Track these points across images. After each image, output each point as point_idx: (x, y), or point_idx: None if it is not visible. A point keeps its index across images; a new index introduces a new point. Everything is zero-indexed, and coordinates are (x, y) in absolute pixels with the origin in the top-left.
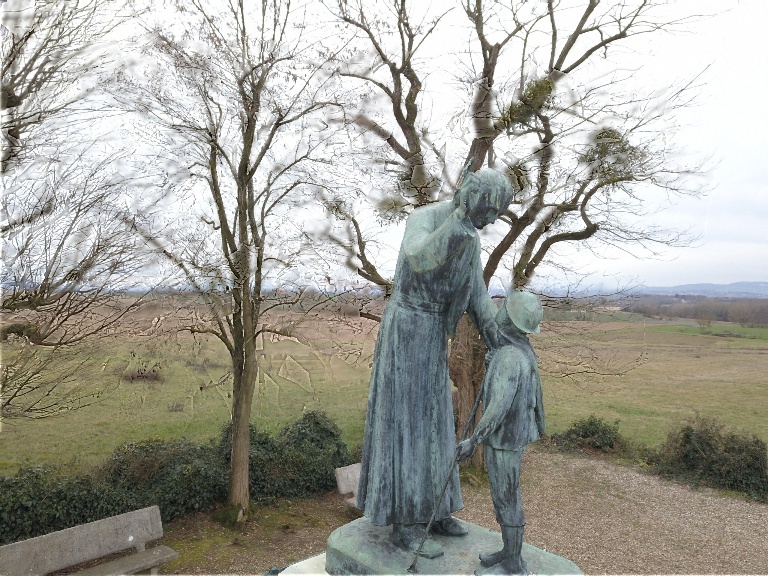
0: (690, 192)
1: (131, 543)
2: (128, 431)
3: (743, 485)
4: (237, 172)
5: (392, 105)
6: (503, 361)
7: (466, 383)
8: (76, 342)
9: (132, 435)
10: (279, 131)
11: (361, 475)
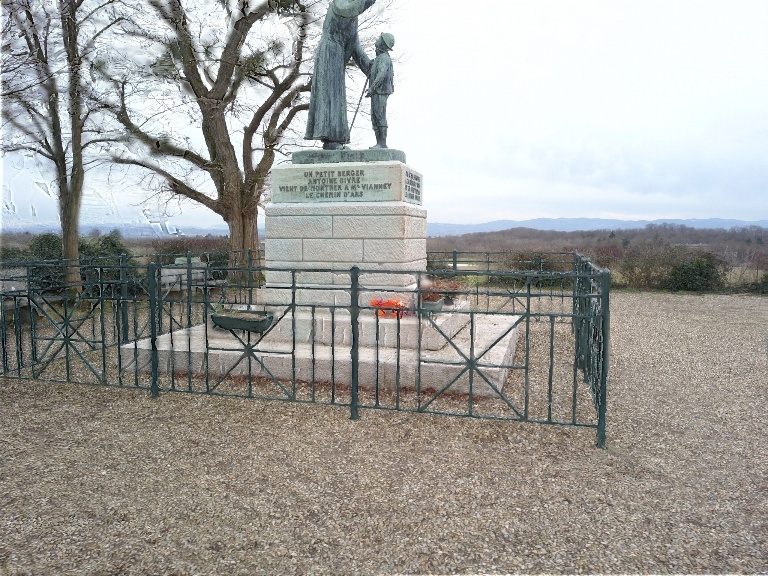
0: None
1: None
2: None
3: None
4: None
5: None
6: (383, 57)
7: (237, 215)
8: (5, 96)
9: None
10: None
11: (309, 122)
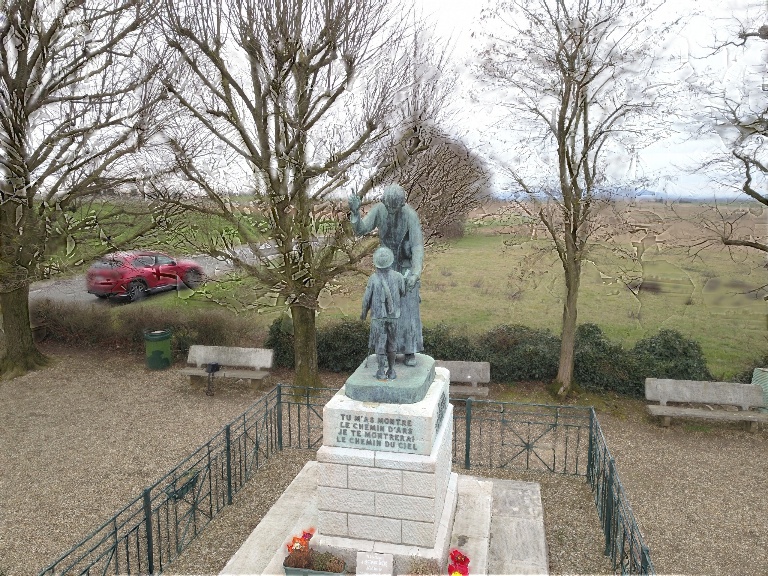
0: None
1: (469, 380)
2: (506, 316)
3: None
4: (557, 129)
5: None
6: None
7: None
8: None
9: (509, 319)
10: (582, 92)
11: None
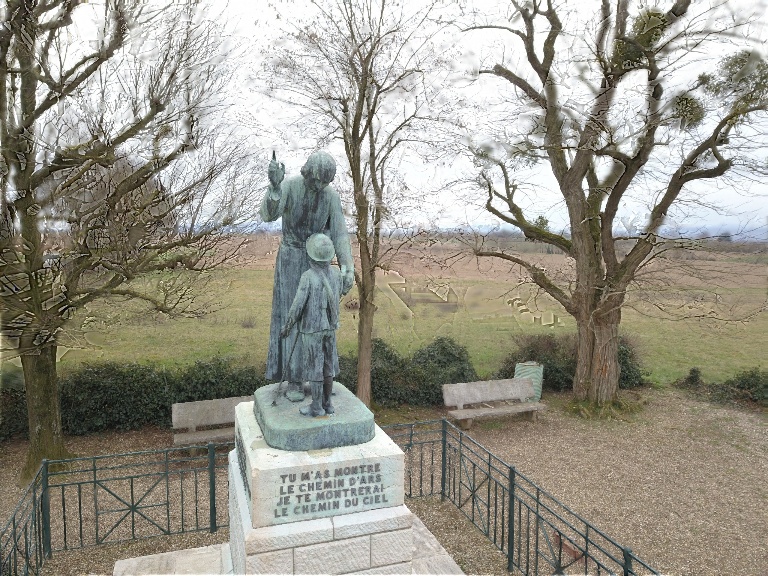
0: None
1: None
2: None
3: None
4: (351, 135)
5: (526, 51)
6: None
7: None
8: (212, 269)
9: None
10: (380, 98)
11: None
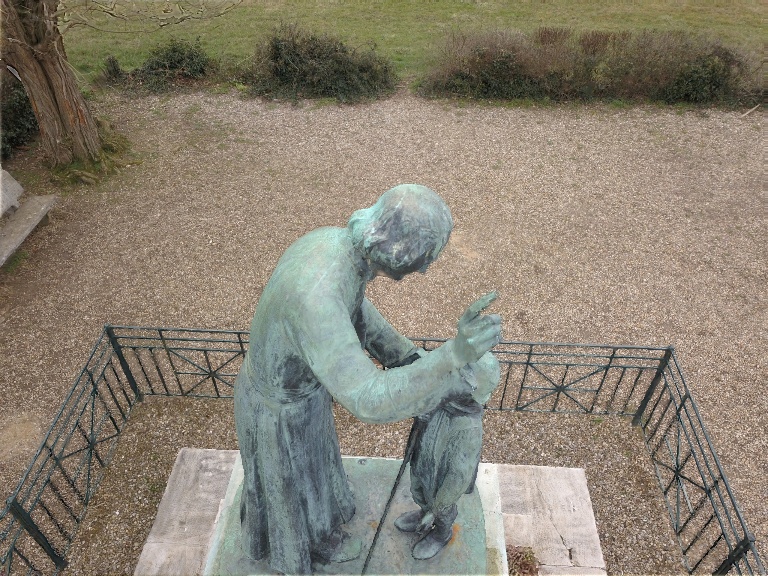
0: None
1: None
2: None
3: (333, 90)
4: None
5: None
6: (469, 444)
7: (27, 62)
8: None
9: None
10: None
11: (253, 541)
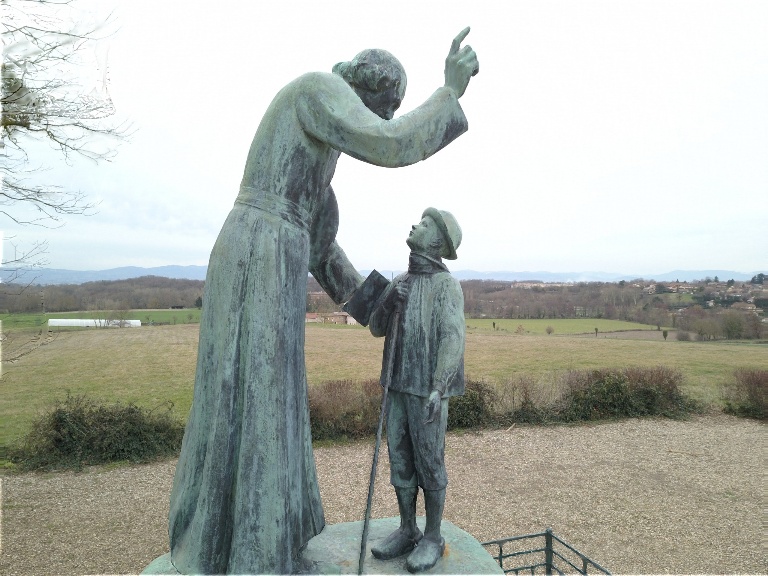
0: (91, 155)
1: None
2: None
3: (125, 453)
4: None
5: None
6: (455, 289)
7: None
8: None
9: None
10: None
11: (211, 515)
